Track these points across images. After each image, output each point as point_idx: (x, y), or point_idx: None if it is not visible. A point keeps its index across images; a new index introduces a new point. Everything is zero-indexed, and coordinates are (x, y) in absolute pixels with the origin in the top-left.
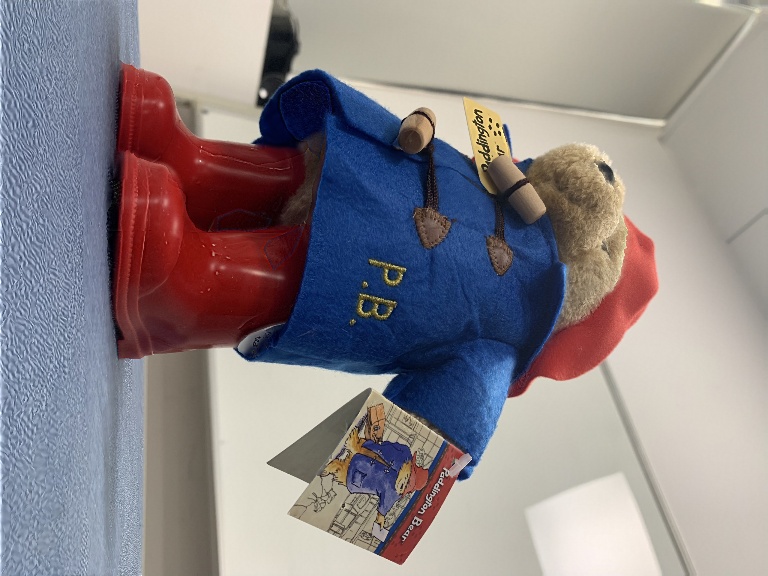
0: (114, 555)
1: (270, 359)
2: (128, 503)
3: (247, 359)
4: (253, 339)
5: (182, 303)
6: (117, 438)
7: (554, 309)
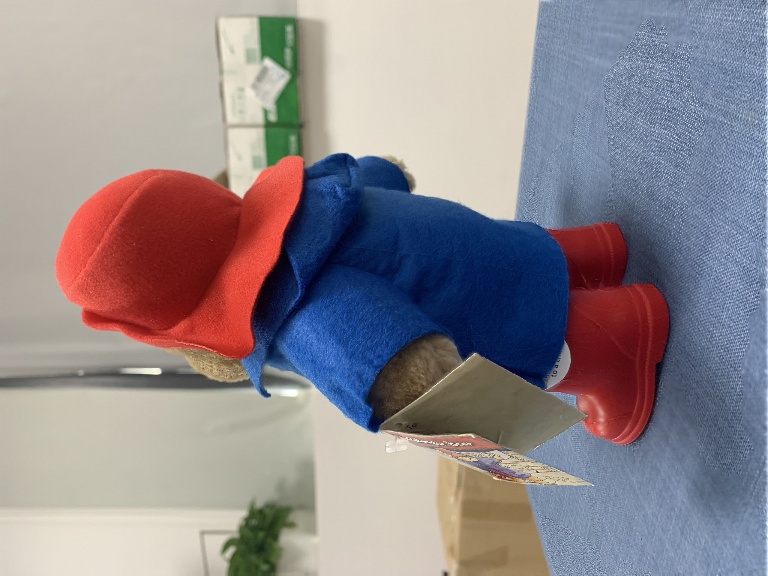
0: (767, 406)
1: (546, 357)
2: (764, 140)
3: (564, 345)
4: (558, 374)
5: (604, 396)
6: (705, 357)
7: (264, 385)
